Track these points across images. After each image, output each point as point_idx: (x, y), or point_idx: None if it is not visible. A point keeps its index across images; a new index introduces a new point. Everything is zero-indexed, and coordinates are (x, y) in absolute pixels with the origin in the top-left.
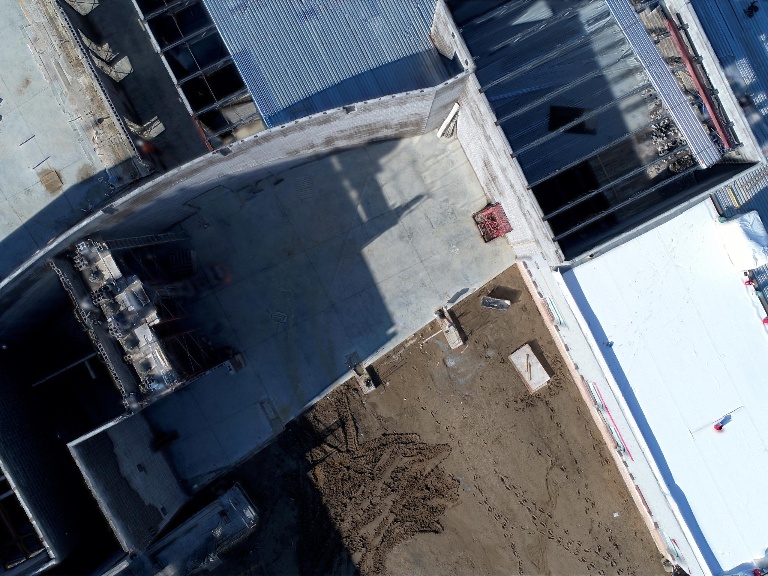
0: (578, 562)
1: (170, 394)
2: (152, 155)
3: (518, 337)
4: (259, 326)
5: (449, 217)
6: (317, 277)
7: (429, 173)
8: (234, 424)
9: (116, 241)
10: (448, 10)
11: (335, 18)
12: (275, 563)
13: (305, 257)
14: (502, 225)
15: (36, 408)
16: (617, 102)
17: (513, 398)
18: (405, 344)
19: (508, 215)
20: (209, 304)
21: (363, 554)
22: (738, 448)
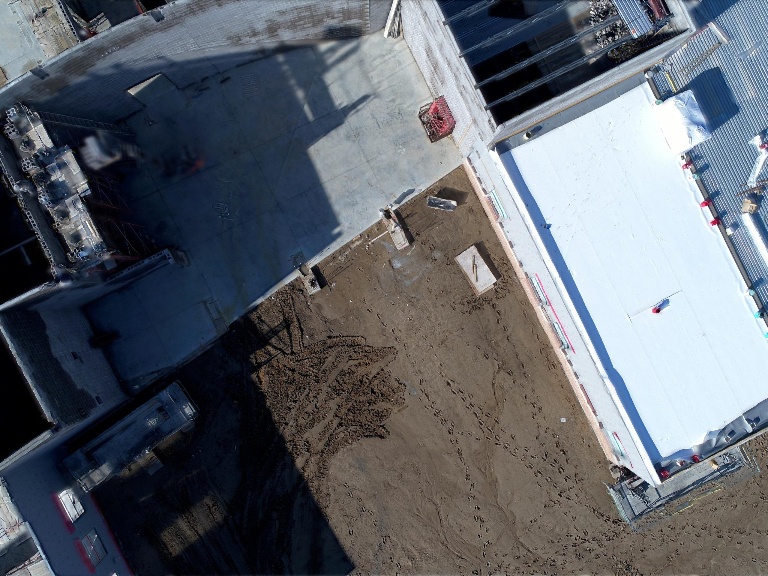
0: (525, 468)
1: (112, 293)
2: None
3: (465, 239)
4: (204, 225)
5: (396, 117)
6: (263, 176)
7: (376, 73)
8: (177, 324)
9: (50, 114)
10: None
11: None
12: (218, 467)
13: (251, 156)
14: (445, 118)
15: None
16: None
17: (459, 301)
18: (351, 245)
19: (450, 106)
20: (153, 202)
21: (307, 459)
22: (676, 333)
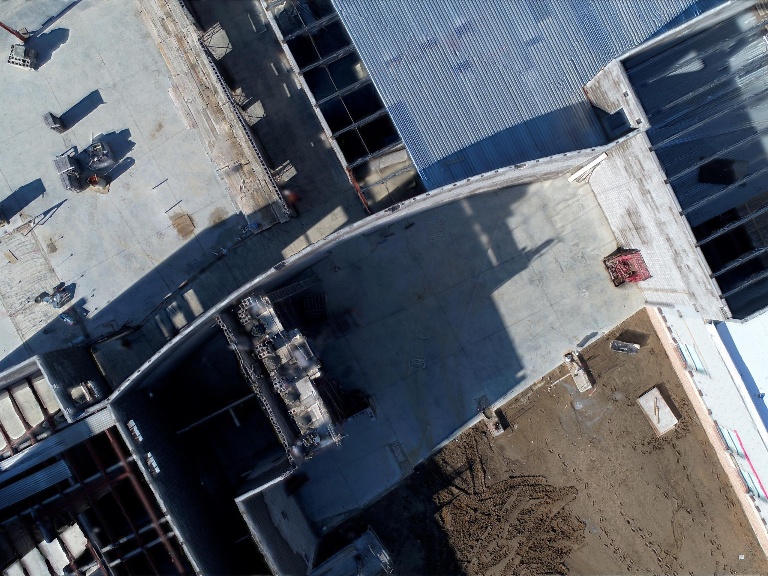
0: None
1: None
2: (288, 200)
3: (646, 380)
4: (389, 369)
5: (579, 261)
6: (447, 320)
7: (559, 217)
8: (363, 466)
9: (274, 293)
10: (624, 70)
11: (489, 70)
12: None
13: (435, 301)
14: (641, 272)
15: (183, 456)
16: None
17: (640, 441)
18: (533, 387)
19: (649, 263)
20: (339, 347)
21: None
22: None
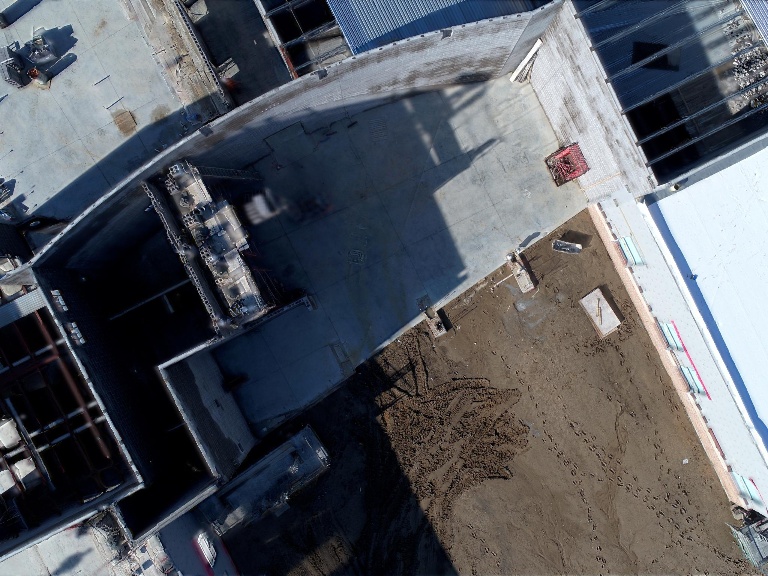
0: (647, 509)
1: (240, 336)
2: (228, 94)
3: (588, 282)
4: (331, 268)
5: (521, 161)
6: (389, 220)
7: (502, 117)
8: (304, 367)
9: (204, 168)
10: None
11: None
12: (343, 509)
13: (377, 199)
14: (579, 165)
15: (115, 341)
16: (709, 30)
17: (583, 343)
18: (476, 288)
19: (586, 154)
20: (281, 246)
21: (432, 500)
22: None
